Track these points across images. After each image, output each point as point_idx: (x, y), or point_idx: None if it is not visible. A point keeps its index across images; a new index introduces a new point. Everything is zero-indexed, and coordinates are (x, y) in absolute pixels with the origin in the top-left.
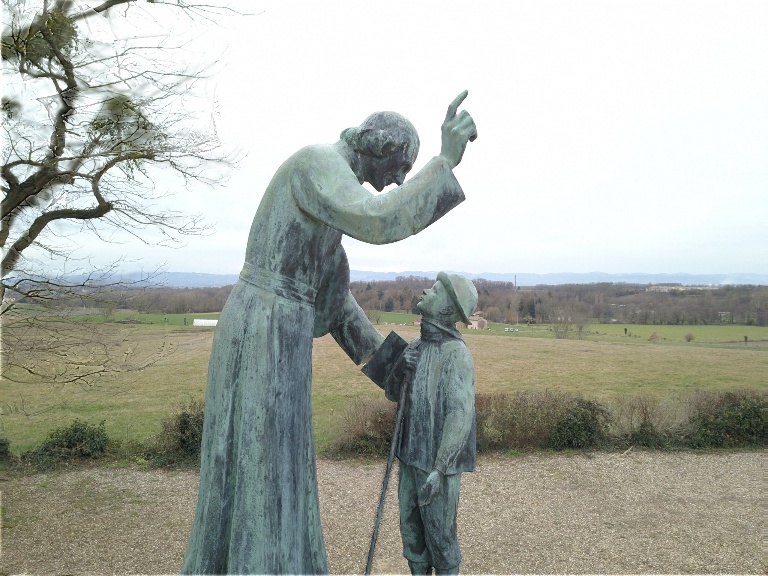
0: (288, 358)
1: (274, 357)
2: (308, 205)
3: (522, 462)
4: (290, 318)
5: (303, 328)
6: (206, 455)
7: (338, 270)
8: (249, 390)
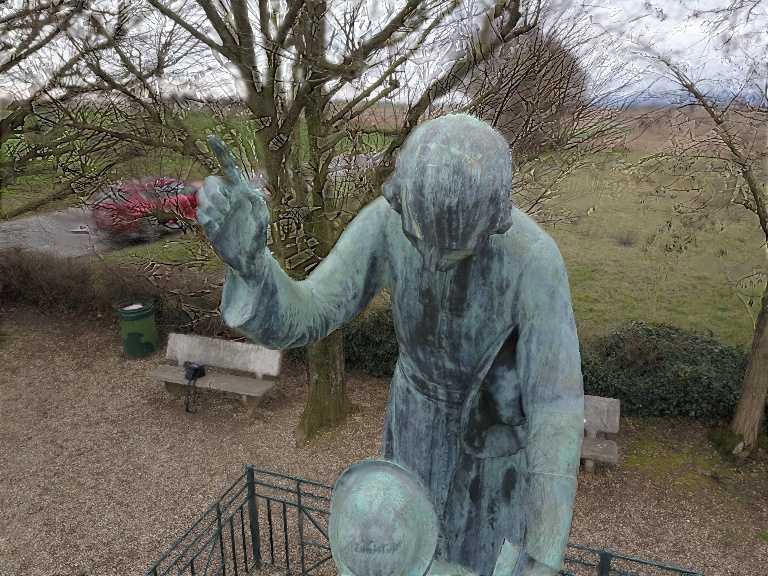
0: (398, 433)
1: (391, 421)
2: None
3: None
4: (399, 393)
5: (412, 415)
6: None
7: (473, 378)
8: None
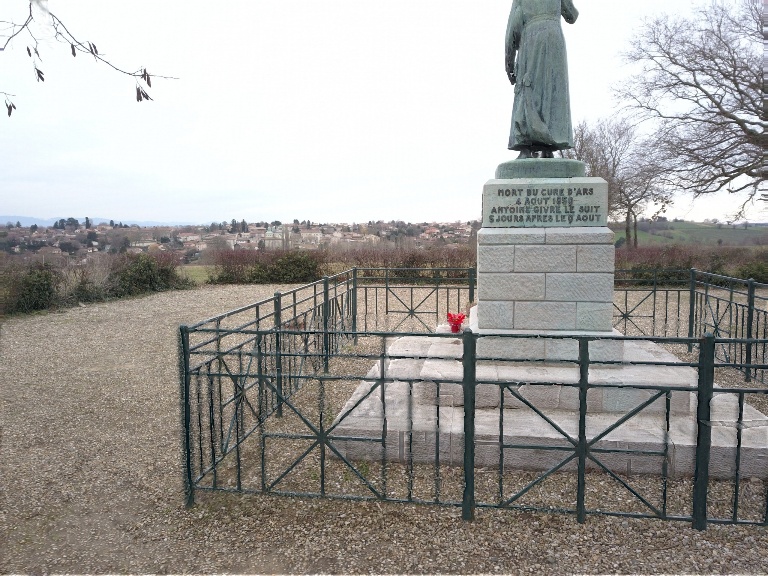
0: None
1: None
2: (565, 2)
3: (15, 324)
4: None
5: None
6: (551, 84)
7: None
8: (566, 60)
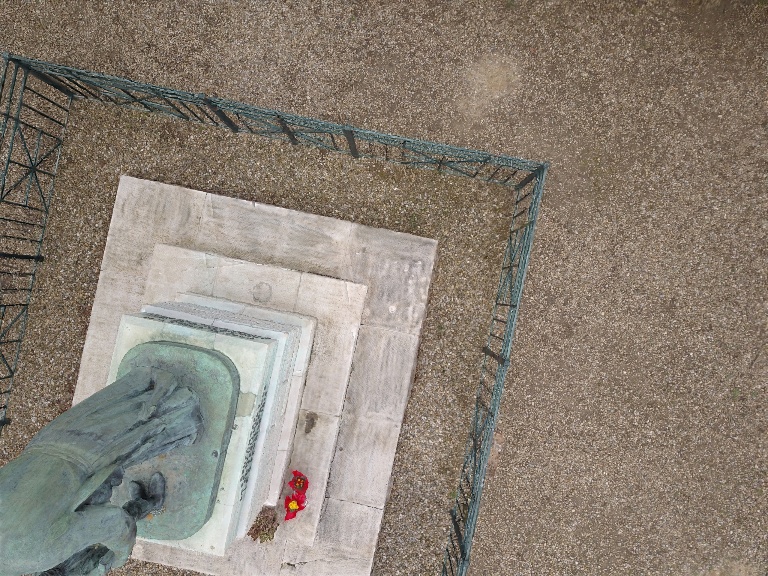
0: None
1: None
2: None
3: None
4: None
5: None
6: None
7: None
8: None
